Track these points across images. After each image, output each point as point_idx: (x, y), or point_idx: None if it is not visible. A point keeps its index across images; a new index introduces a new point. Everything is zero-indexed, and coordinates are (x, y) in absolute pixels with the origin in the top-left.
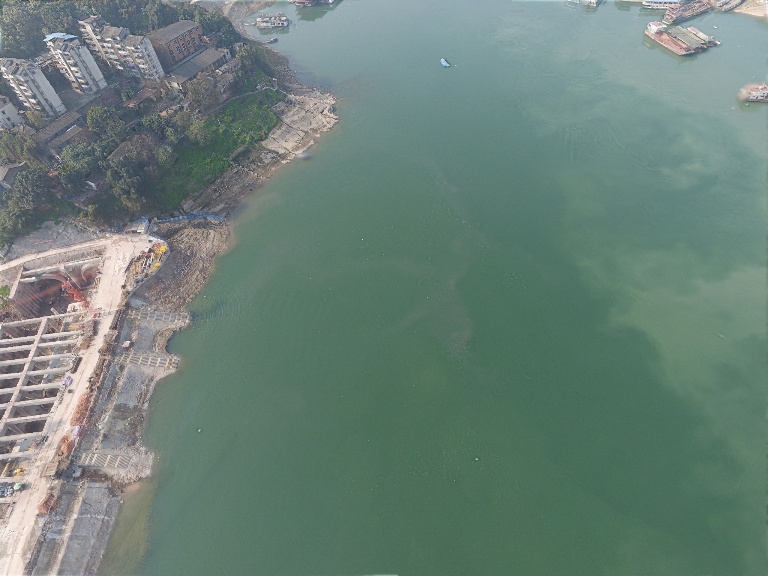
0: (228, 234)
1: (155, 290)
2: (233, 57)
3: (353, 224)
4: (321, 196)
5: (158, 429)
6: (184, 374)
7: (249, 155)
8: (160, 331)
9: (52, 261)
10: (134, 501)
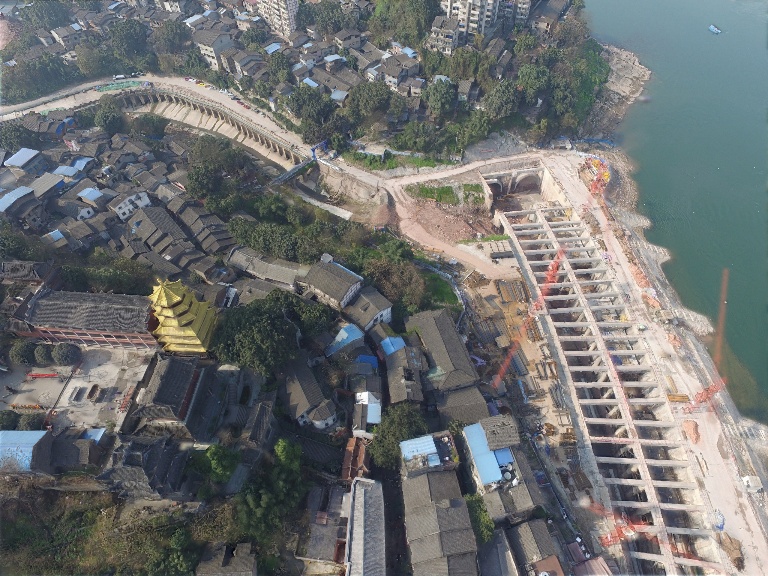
0: (626, 157)
1: (614, 194)
2: (565, 7)
3: (735, 155)
4: (688, 132)
5: (692, 299)
6: (677, 261)
7: (602, 94)
8: (633, 227)
9: (498, 168)
10: (716, 348)
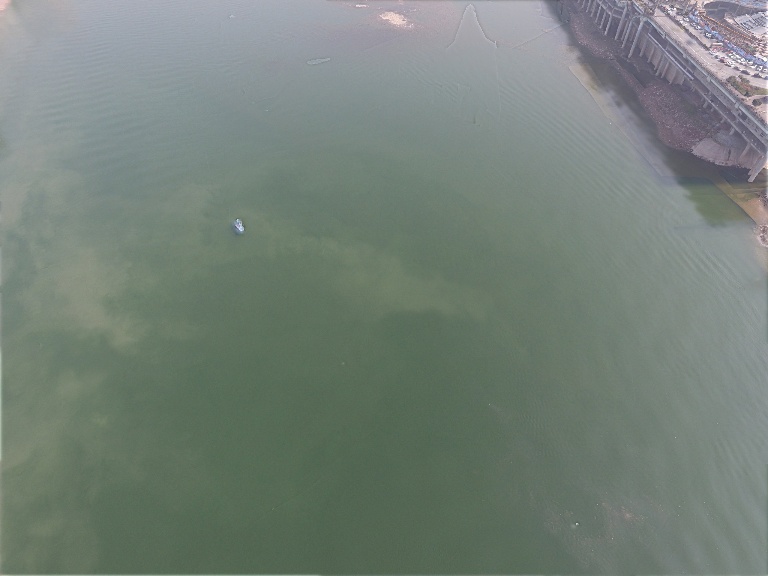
0: None
1: None
2: None
3: None
4: None
5: None
6: None
7: None
8: None
9: None
10: None
